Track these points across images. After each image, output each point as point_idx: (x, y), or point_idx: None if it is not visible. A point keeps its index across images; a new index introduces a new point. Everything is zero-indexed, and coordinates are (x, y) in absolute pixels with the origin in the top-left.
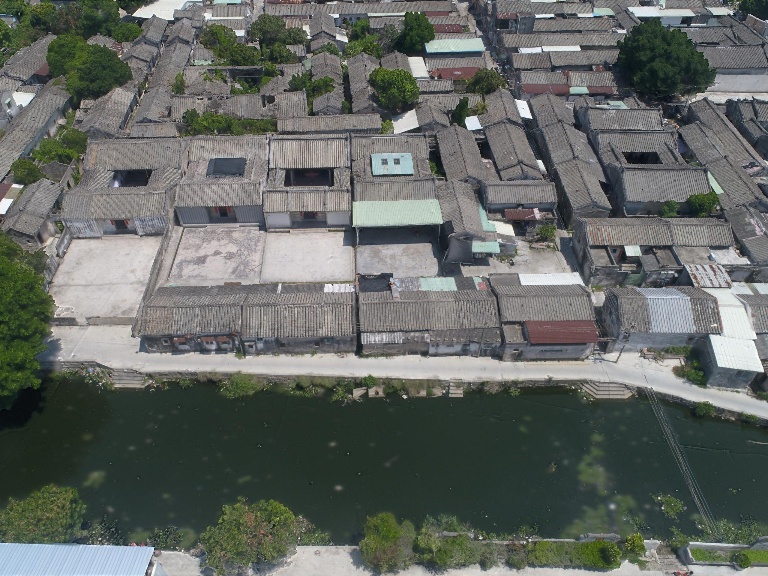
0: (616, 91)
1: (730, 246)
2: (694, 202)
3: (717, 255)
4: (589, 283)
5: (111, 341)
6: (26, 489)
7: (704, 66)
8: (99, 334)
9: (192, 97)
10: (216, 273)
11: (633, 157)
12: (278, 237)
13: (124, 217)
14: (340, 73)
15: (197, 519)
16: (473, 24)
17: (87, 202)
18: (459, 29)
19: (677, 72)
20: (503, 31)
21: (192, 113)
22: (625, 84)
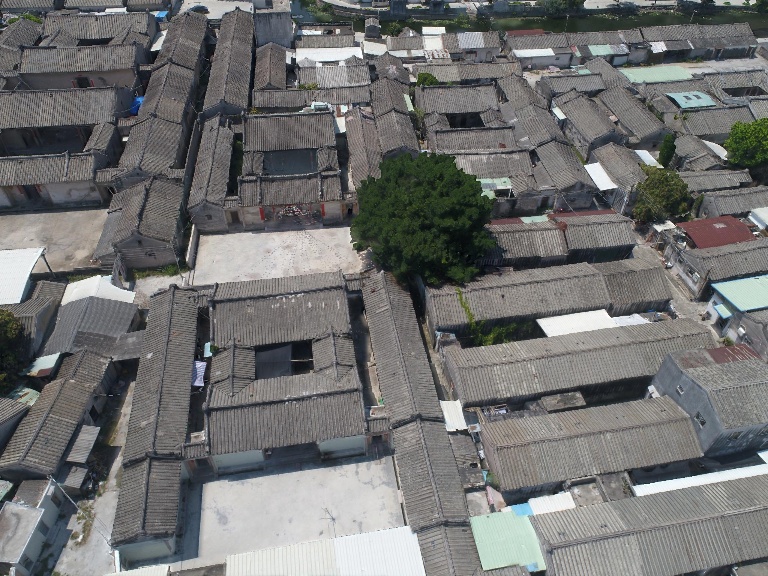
0: None
1: None
2: None
3: None
4: None
5: None
6: (722, 20)
7: None
8: None
9: None
10: (744, 69)
11: None
12: None
13: None
14: None
15: None
16: None
17: None
18: None
19: None
20: None
21: None
22: None
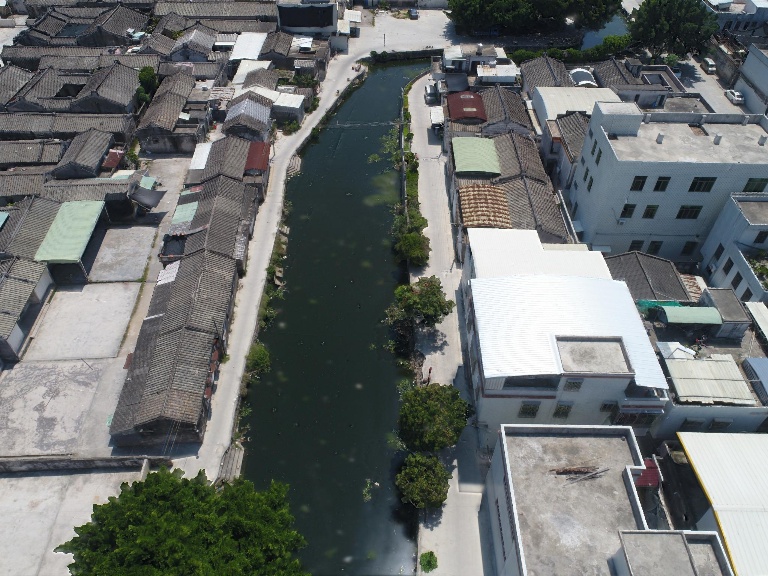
0: None
1: None
2: (148, 78)
3: None
4: None
5: None
6: (362, 527)
7: None
8: None
9: None
10: (81, 402)
11: None
12: (36, 349)
13: None
14: None
15: (390, 373)
16: None
17: None
18: None
19: None
20: None
21: None
22: None
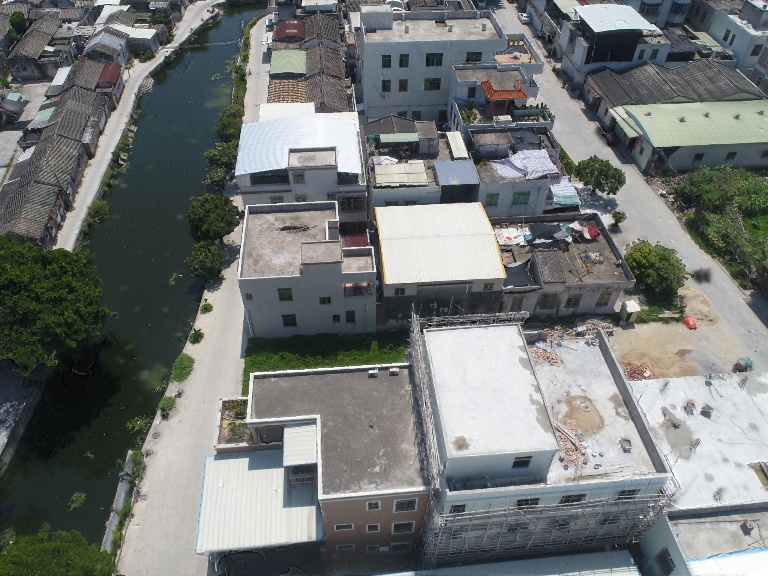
0: None
1: (61, 24)
2: (18, 21)
3: None
4: None
5: None
6: (166, 299)
7: None
8: None
9: None
10: None
11: None
12: None
13: None
14: None
15: None
16: None
17: None
18: None
19: None
20: None
21: None
22: None
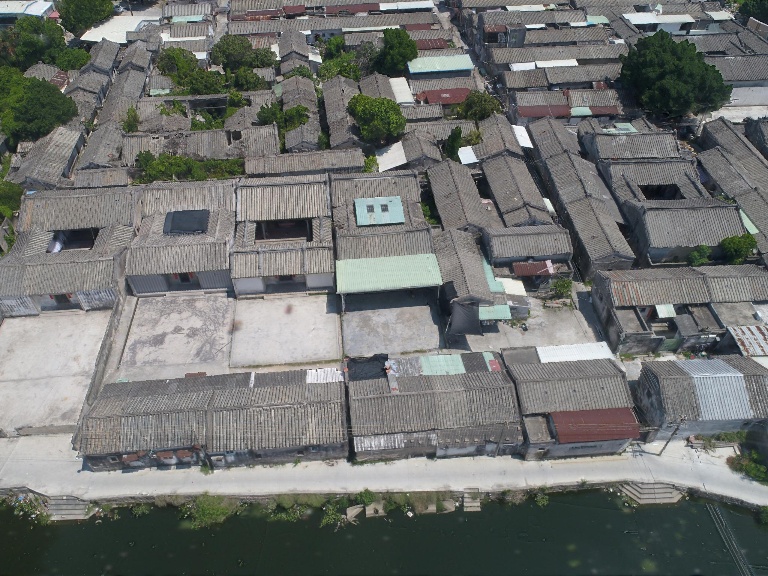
0: (621, 111)
1: None
2: (729, 247)
3: (762, 311)
4: (617, 351)
5: (47, 457)
6: None
7: (718, 82)
8: (32, 448)
9: (146, 136)
10: (177, 356)
11: (649, 189)
12: (250, 305)
13: (64, 291)
14: (315, 100)
15: None
16: (457, 36)
17: (19, 275)
18: (444, 44)
19: (690, 90)
20: (492, 45)
21: (146, 156)
22: (631, 103)
